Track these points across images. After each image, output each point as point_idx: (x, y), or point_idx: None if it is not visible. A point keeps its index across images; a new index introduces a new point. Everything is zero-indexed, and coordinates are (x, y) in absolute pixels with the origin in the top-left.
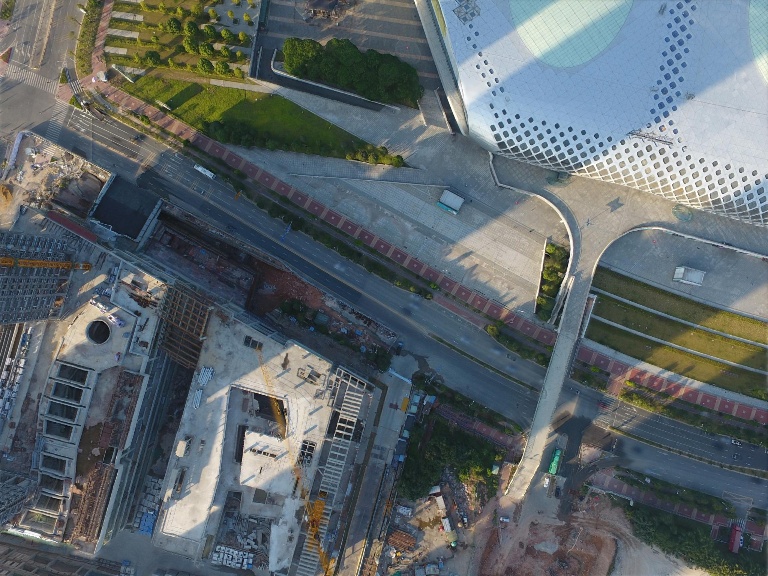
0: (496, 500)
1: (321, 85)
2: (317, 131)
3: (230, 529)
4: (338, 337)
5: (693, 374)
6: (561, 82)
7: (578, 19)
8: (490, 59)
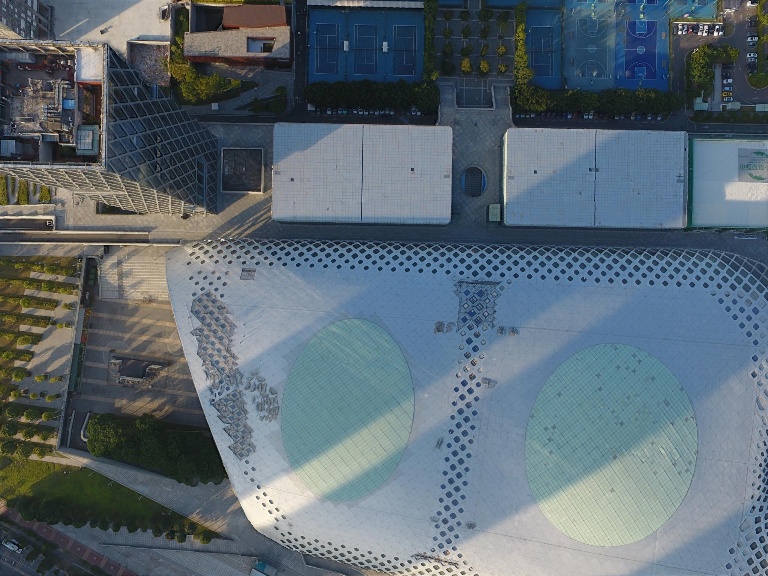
0: None
1: None
2: (127, 503)
3: None
4: None
5: None
6: (341, 513)
7: (353, 458)
8: (269, 492)
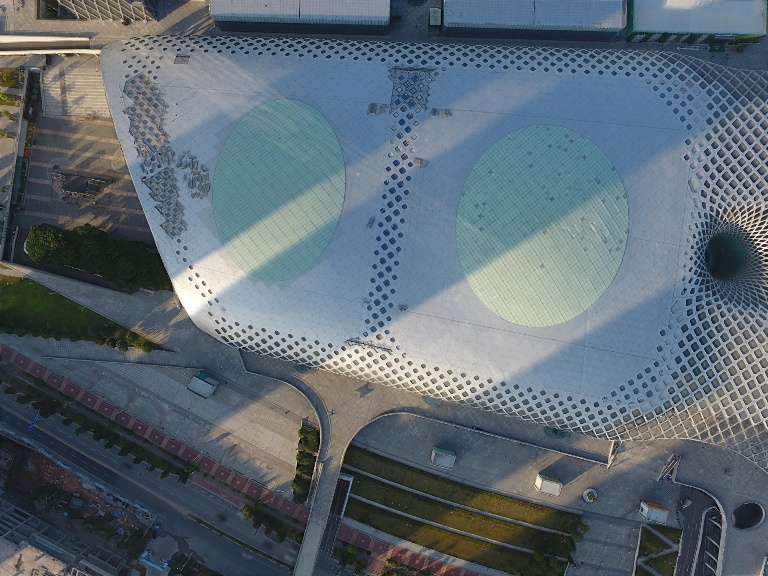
0: None
1: (74, 268)
2: (69, 314)
3: None
4: (92, 522)
5: (454, 552)
6: (273, 294)
7: (284, 235)
8: (201, 272)
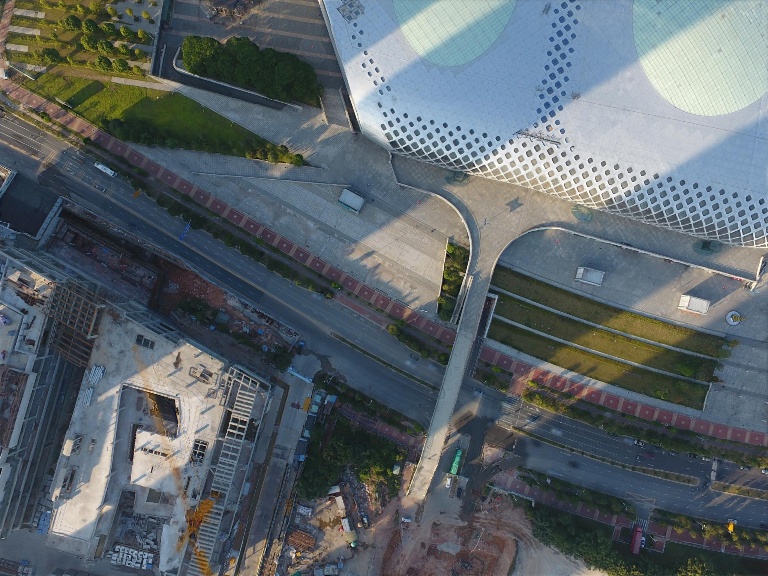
0: (398, 500)
1: (223, 83)
2: (218, 129)
3: (129, 529)
4: (238, 336)
5: (596, 374)
6: (447, 81)
7: (461, 18)
8: (375, 58)
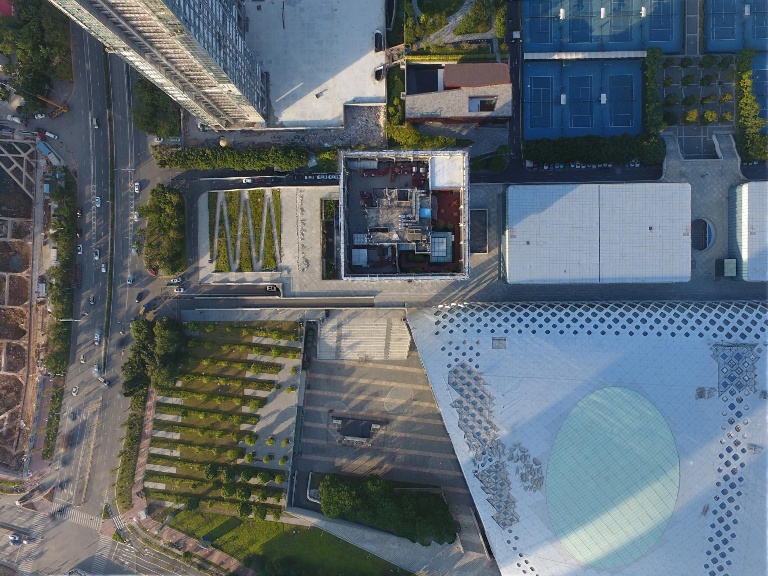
0: None
1: None
2: (355, 561)
3: None
4: None
5: None
6: None
7: (619, 527)
8: (531, 559)
